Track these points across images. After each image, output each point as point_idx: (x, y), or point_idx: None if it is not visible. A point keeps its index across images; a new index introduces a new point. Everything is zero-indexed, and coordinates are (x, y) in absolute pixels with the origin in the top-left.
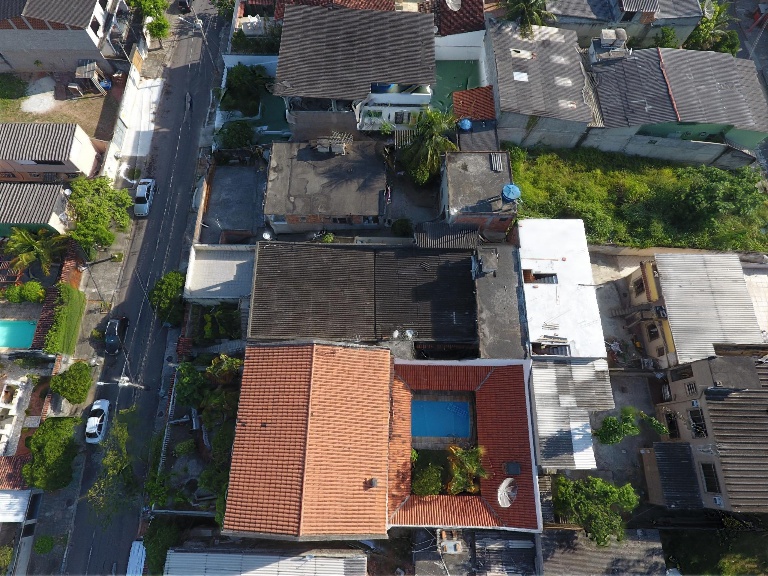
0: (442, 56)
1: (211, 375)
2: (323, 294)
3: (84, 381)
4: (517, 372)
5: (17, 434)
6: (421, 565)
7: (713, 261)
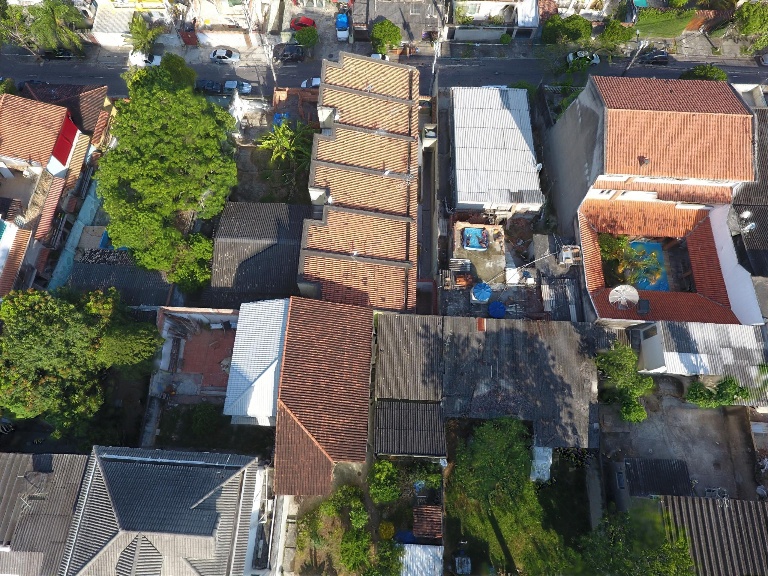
0: None
1: None
2: (764, 162)
3: (621, 37)
4: None
5: None
6: (545, 239)
7: None
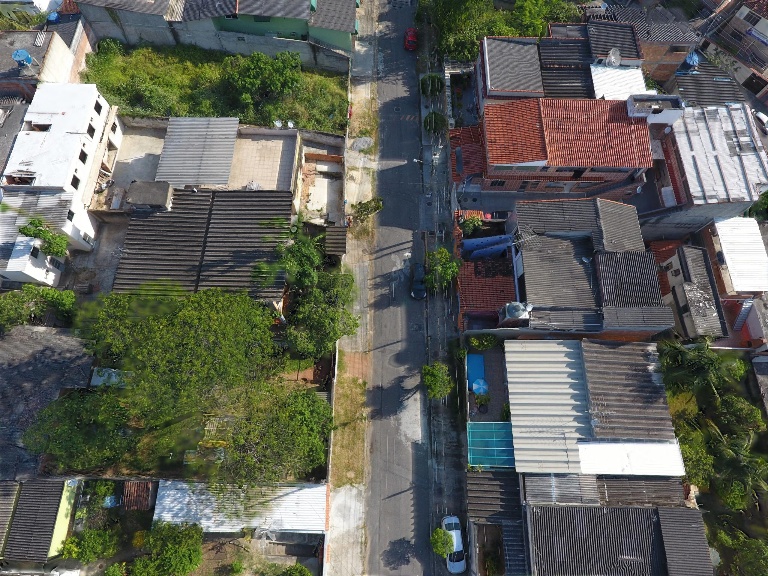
0: None
1: None
2: None
3: None
4: None
5: None
6: None
7: (216, 122)
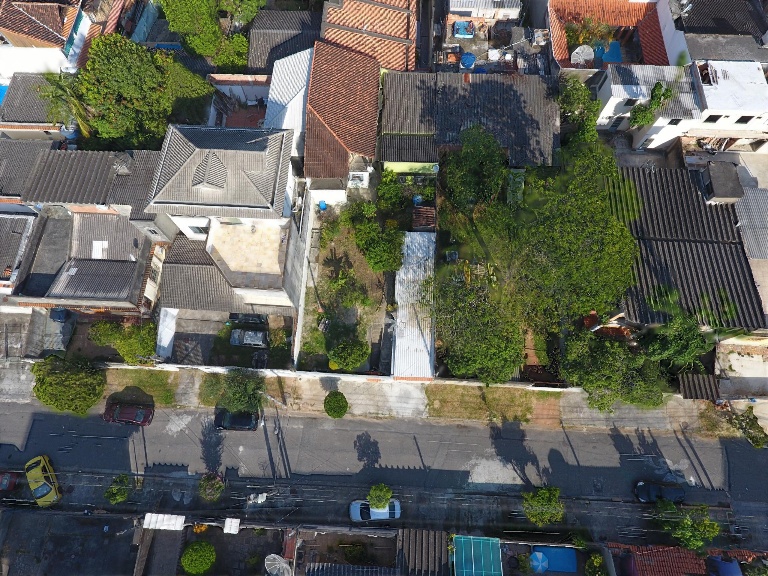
0: None
1: None
2: None
3: None
4: None
5: None
6: (522, 30)
7: None
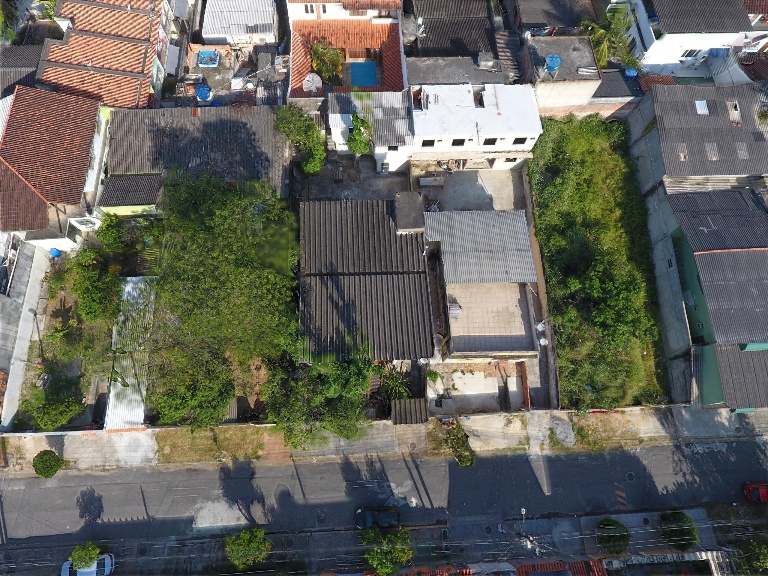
0: (719, 78)
1: None
2: None
3: None
4: None
5: None
6: (268, 56)
7: (525, 258)
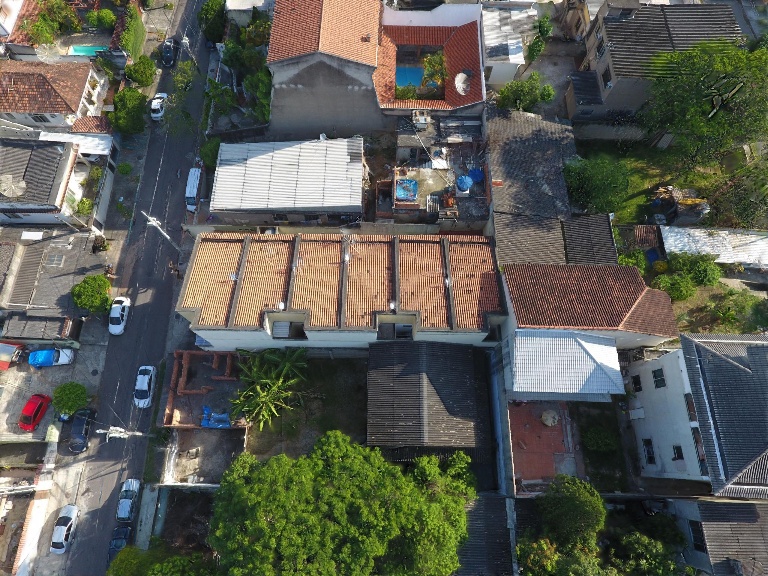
0: None
1: (250, 36)
2: None
3: (151, 66)
4: (473, 25)
5: (98, 115)
6: (402, 137)
7: None
